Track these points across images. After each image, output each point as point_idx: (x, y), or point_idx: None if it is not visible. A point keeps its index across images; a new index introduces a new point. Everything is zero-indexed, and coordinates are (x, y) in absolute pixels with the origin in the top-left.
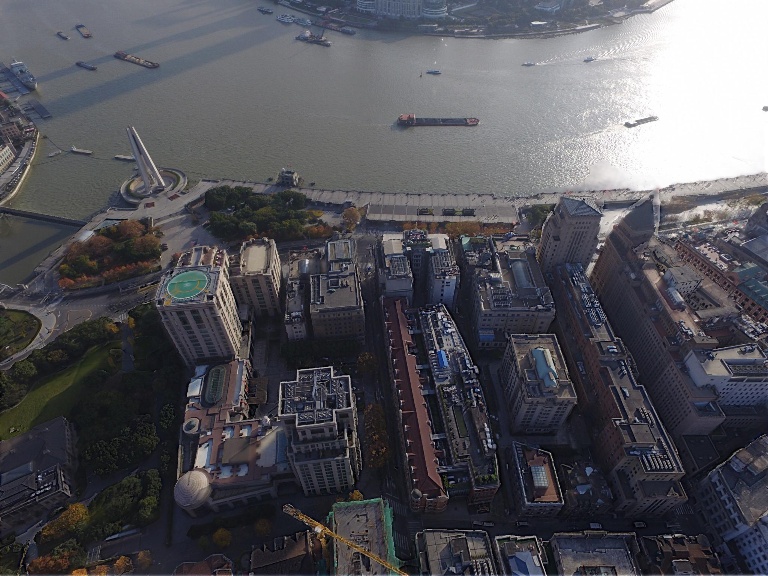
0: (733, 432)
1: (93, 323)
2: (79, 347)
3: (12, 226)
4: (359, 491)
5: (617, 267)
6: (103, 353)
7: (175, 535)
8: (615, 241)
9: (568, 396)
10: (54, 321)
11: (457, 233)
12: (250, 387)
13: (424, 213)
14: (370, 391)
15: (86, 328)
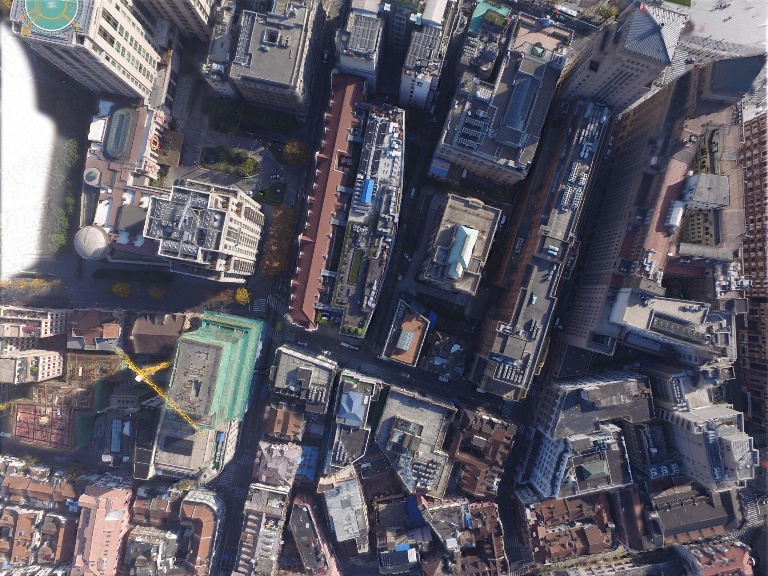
0: (629, 348)
1: None
2: None
3: None
4: (249, 288)
5: (652, 133)
6: (2, 35)
7: (85, 270)
8: (680, 90)
9: (468, 288)
10: None
11: None
12: (163, 142)
13: None
14: (293, 185)
15: None
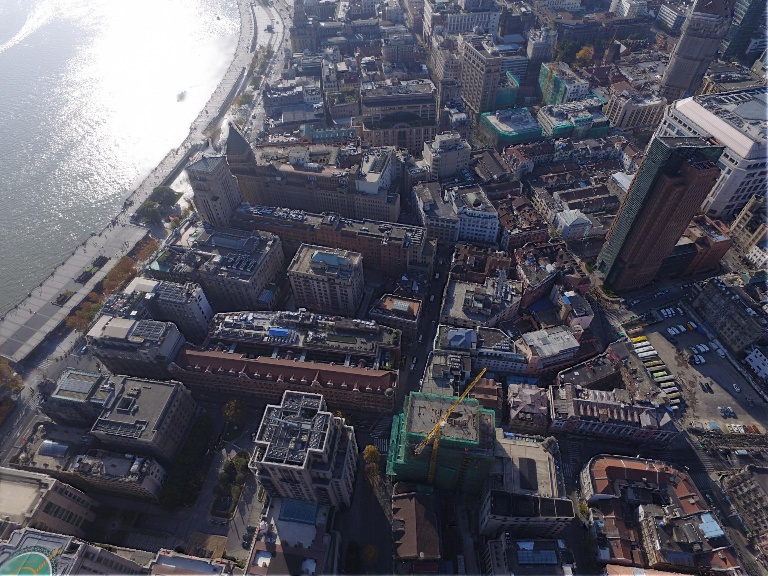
0: None
1: None
2: None
3: None
4: None
5: (261, 185)
6: None
7: None
8: (238, 172)
9: (357, 258)
10: None
11: (122, 280)
12: None
13: (65, 300)
14: None
15: None
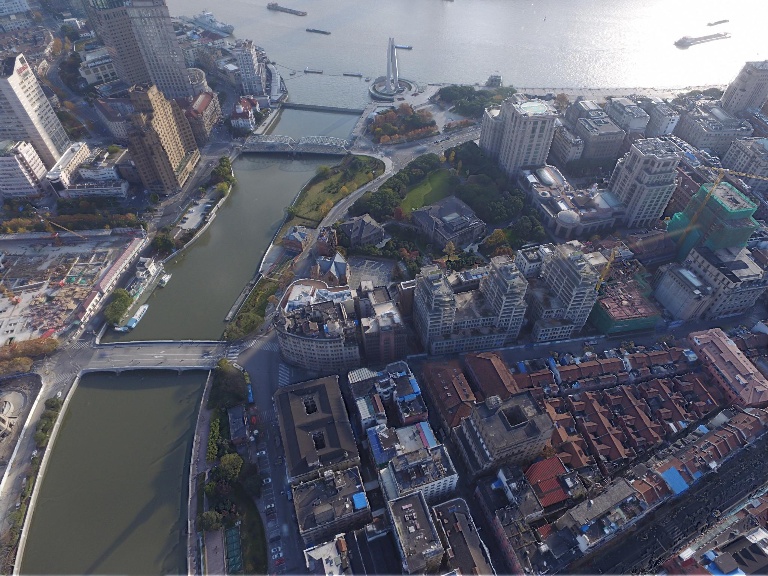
0: None
1: (431, 154)
2: (429, 167)
3: (300, 116)
4: None
5: None
6: (439, 174)
7: None
8: None
9: None
10: (390, 160)
11: None
12: None
13: None
14: None
15: (428, 157)
